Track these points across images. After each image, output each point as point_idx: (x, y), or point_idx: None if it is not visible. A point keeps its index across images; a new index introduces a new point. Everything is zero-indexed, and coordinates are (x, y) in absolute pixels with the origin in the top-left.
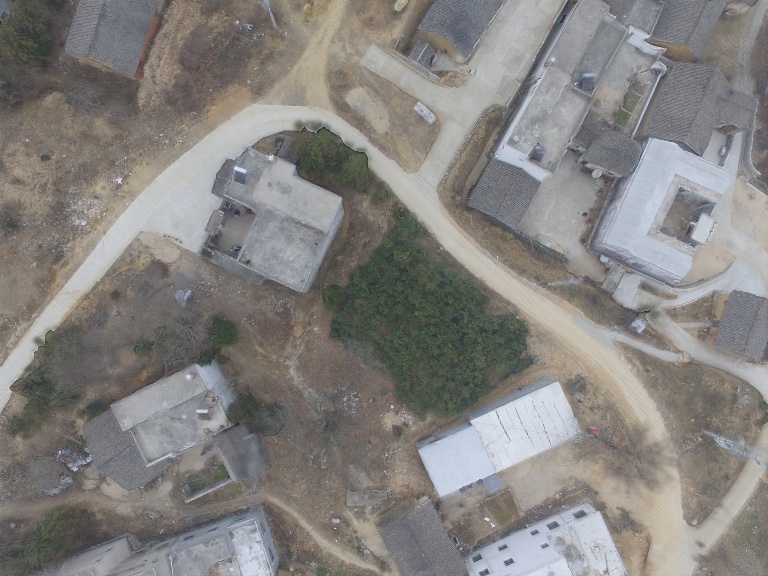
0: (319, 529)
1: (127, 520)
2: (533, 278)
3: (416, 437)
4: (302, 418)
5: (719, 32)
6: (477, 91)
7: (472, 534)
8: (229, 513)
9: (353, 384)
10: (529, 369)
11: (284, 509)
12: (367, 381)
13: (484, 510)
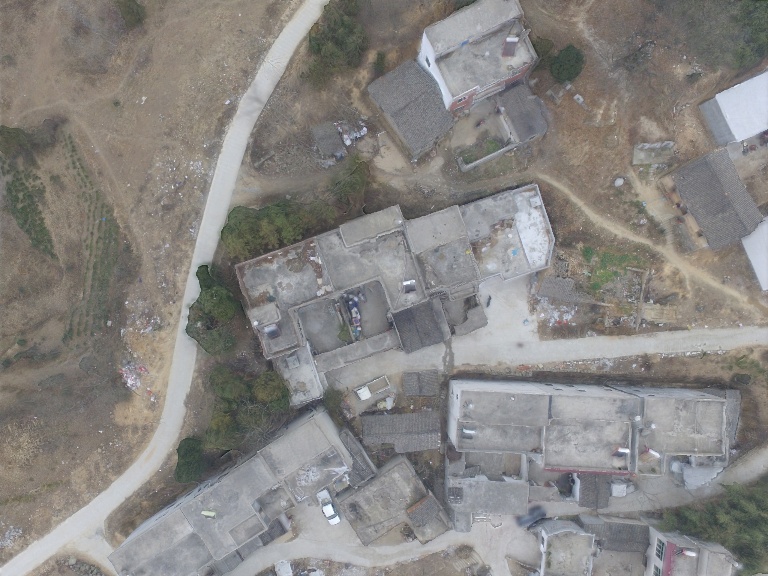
0: (591, 203)
1: (401, 192)
2: None
3: (707, 90)
4: (592, 71)
5: None
6: None
7: (755, 197)
8: (498, 191)
9: (648, 31)
10: None
11: (555, 185)
12: (663, 27)
13: (767, 173)
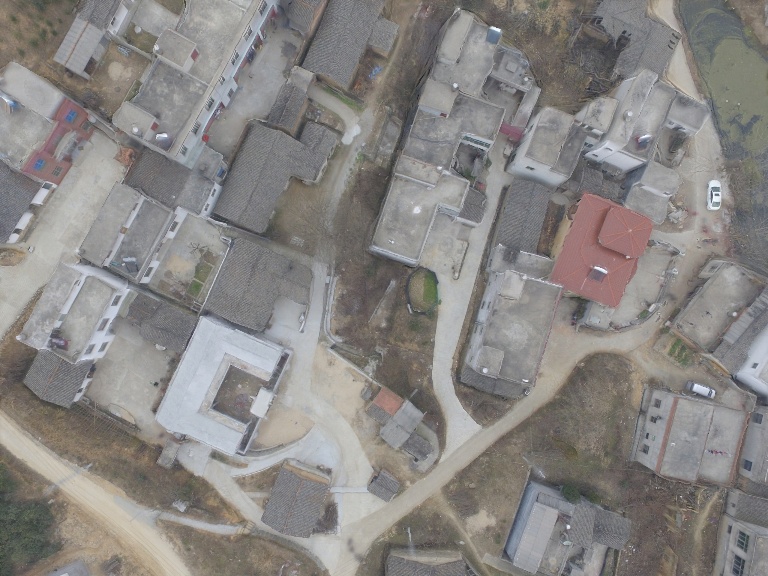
0: None
1: None
2: (75, 459)
3: None
4: None
5: (300, 199)
6: (34, 269)
7: None
8: None
9: None
10: (66, 550)
11: None
12: None
13: None
